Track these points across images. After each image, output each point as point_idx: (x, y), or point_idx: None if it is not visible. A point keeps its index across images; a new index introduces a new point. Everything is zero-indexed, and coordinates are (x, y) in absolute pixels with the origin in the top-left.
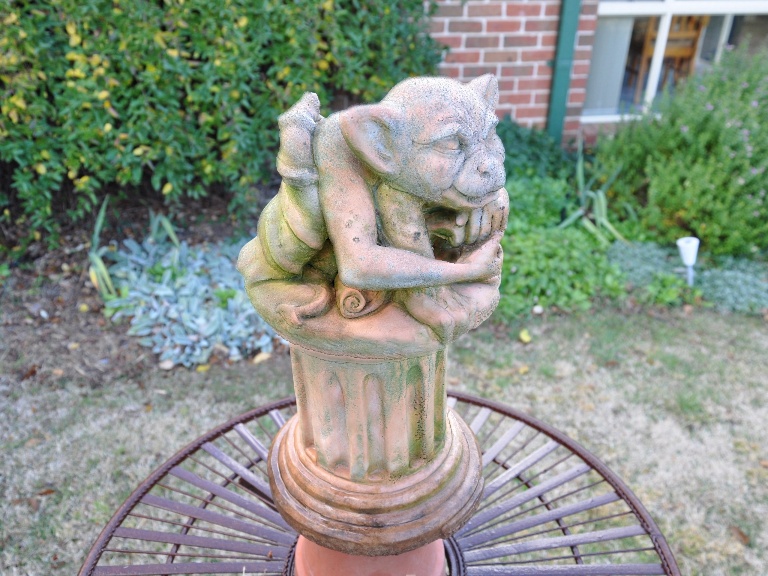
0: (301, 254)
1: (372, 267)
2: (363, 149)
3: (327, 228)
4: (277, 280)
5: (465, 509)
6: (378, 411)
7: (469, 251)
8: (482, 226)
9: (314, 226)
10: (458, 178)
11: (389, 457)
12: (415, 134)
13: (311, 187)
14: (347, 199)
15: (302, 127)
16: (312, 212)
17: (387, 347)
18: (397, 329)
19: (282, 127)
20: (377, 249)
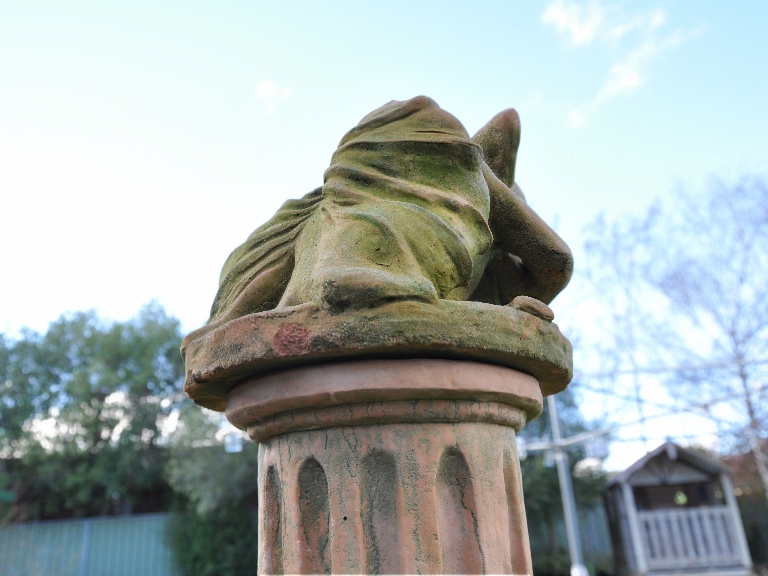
0: (472, 255)
1: None
2: None
3: (522, 209)
4: None
5: None
6: None
7: None
8: None
9: None
10: None
11: None
12: None
13: None
14: None
15: None
16: None
17: None
18: None
19: None
20: None
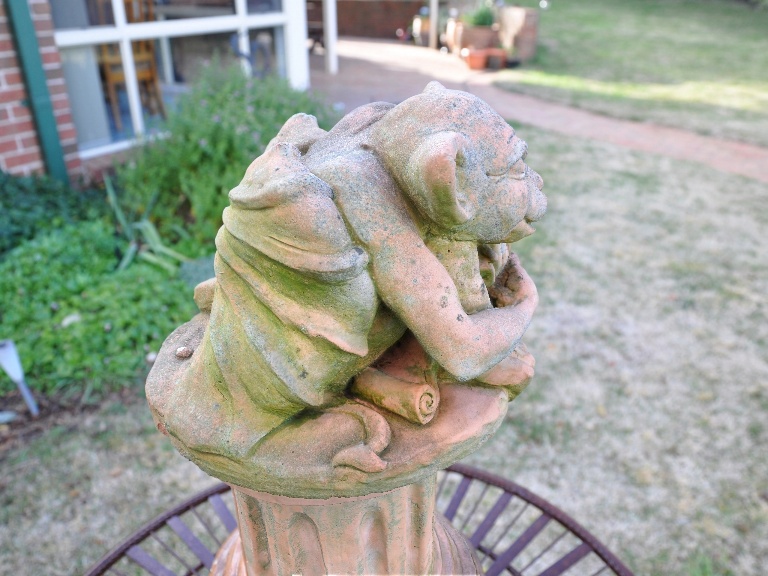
0: (334, 373)
1: (492, 343)
2: (456, 199)
3: (412, 319)
4: (278, 427)
5: (478, 567)
6: (409, 521)
7: (498, 287)
8: (502, 255)
9: (365, 326)
10: (530, 205)
11: (424, 565)
12: (489, 165)
13: (363, 274)
14: (428, 272)
15: (325, 196)
16: (366, 308)
17: (482, 433)
18: (482, 407)
19: (298, 203)
20: (480, 319)
